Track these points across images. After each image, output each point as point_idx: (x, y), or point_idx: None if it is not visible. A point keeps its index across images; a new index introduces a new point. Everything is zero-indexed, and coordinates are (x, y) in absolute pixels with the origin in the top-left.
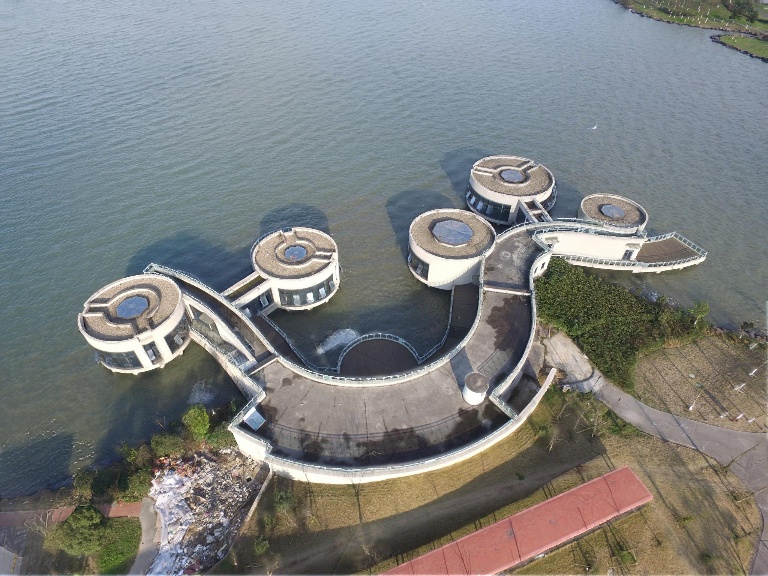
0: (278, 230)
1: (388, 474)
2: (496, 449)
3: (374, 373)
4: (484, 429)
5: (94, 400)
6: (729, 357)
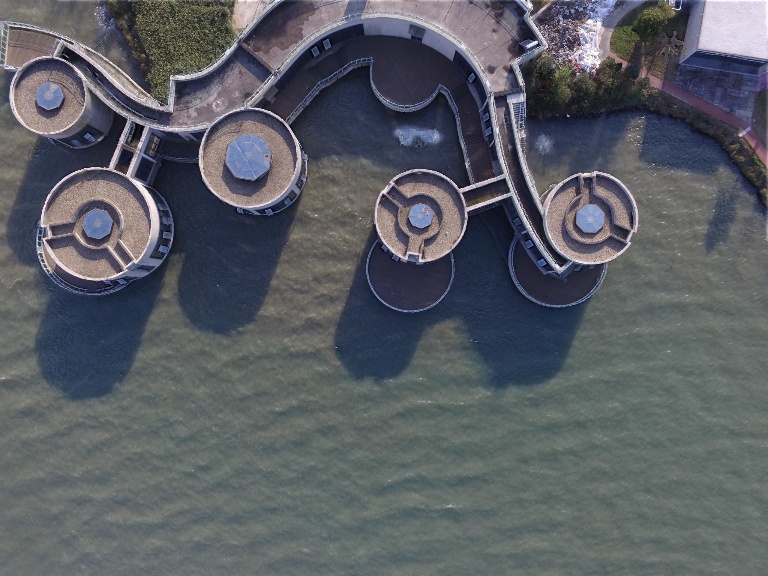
0: None
1: None
2: None
3: (412, 72)
4: None
5: None
6: None
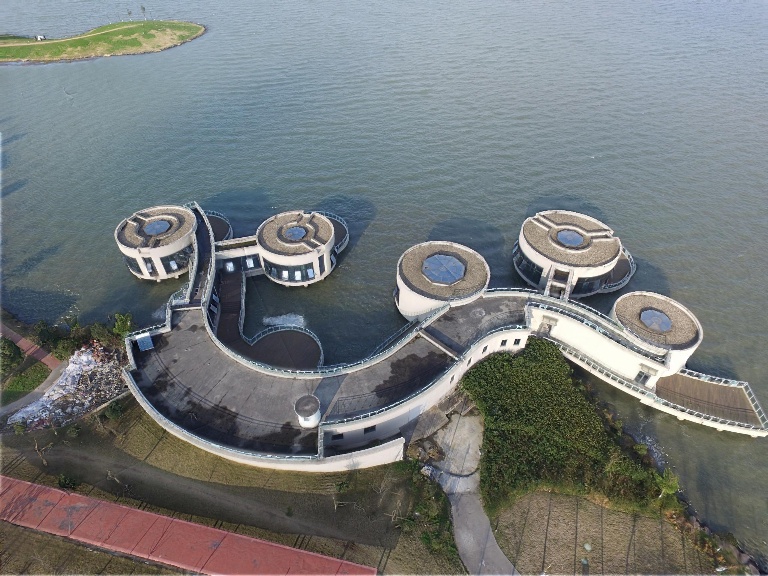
0: (320, 212)
1: (181, 436)
2: (291, 476)
3: (277, 360)
4: (289, 451)
5: (106, 283)
6: (666, 559)
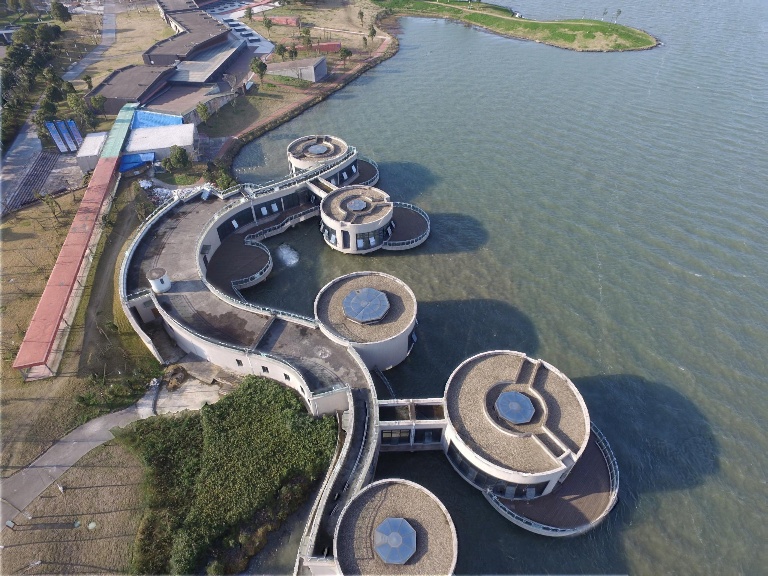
0: None
1: None
2: None
3: (237, 262)
4: (134, 288)
5: None
6: None
